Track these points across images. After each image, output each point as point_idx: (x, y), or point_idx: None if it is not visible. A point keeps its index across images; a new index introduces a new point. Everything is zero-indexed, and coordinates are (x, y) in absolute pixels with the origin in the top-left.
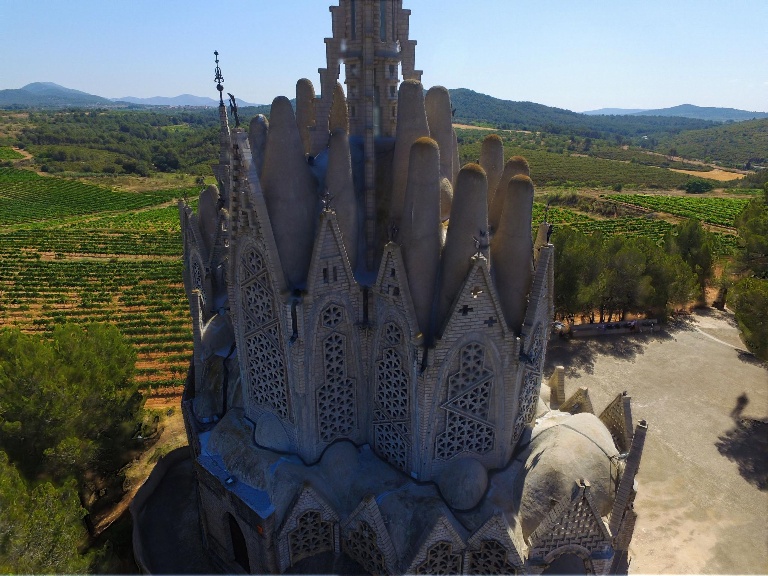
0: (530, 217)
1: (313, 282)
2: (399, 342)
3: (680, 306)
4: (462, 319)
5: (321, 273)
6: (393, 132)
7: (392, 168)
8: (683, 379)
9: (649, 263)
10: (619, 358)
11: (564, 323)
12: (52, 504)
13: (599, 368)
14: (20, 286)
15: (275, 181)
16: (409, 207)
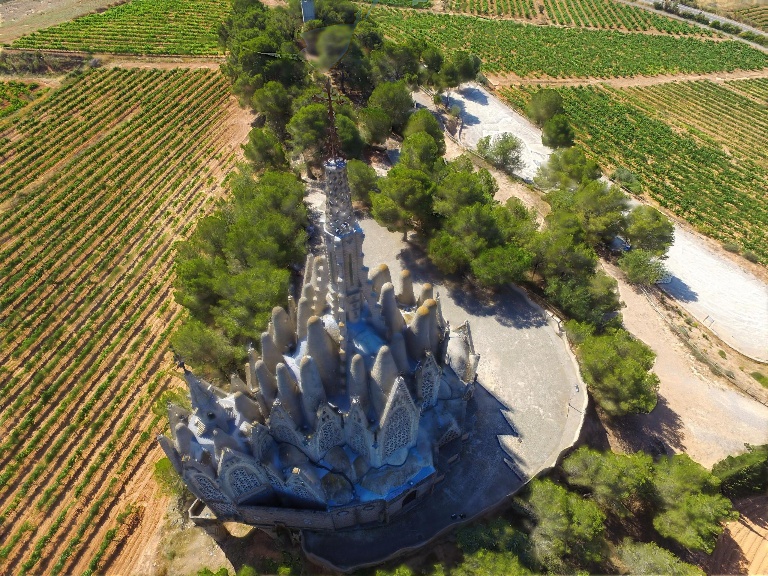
0: None
1: None
2: None
3: None
4: None
5: None
6: (364, 303)
7: (388, 322)
8: None
9: None
10: None
11: None
12: (399, 575)
13: None
14: None
15: None
16: None
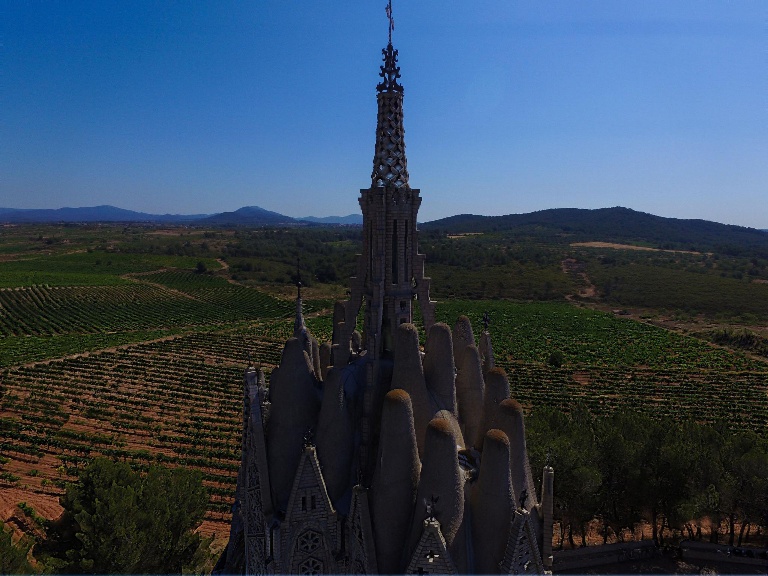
0: (506, 475)
1: (290, 510)
2: None
3: None
4: None
5: (300, 501)
6: None
7: None
8: None
9: None
10: None
11: (675, 533)
12: None
13: None
14: (182, 386)
15: (278, 409)
16: (379, 452)
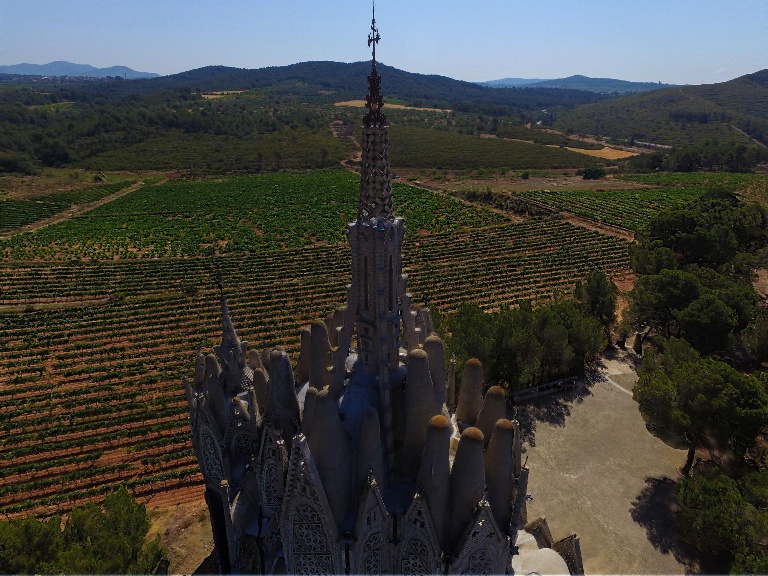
0: None
1: (361, 531)
2: (424, 554)
3: (593, 353)
4: (472, 540)
5: (365, 521)
6: (398, 366)
7: (404, 409)
8: (601, 441)
9: (570, 331)
10: (552, 423)
11: (505, 386)
12: None
13: (539, 438)
14: None
15: (324, 456)
16: (429, 466)
